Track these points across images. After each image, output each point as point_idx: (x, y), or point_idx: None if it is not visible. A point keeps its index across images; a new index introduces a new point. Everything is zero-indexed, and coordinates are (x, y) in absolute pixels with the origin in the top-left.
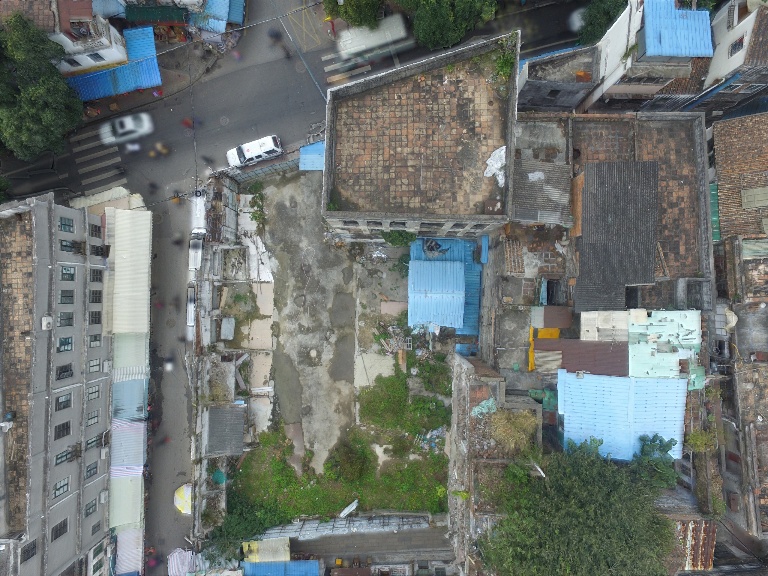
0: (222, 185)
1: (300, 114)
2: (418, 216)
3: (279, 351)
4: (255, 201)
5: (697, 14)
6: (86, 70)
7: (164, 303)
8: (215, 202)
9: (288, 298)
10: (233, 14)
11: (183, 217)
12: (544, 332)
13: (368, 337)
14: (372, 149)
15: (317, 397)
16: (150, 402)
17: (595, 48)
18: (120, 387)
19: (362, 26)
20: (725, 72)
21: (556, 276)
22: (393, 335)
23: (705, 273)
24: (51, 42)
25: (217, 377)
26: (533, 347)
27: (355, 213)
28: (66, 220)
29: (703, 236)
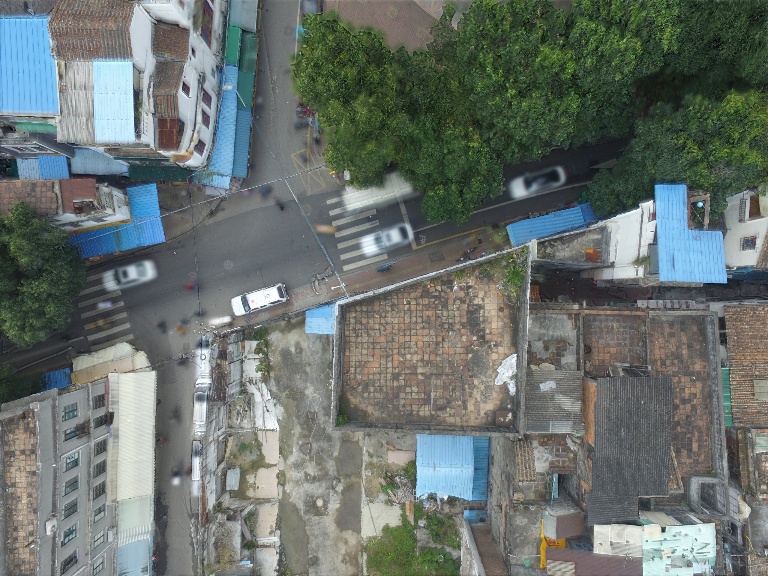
0: (227, 343)
1: (305, 258)
2: (429, 433)
3: (285, 500)
4: (260, 347)
5: (710, 235)
6: (89, 228)
7: (168, 450)
8: (220, 360)
9: (294, 446)
10: (237, 168)
11: (187, 362)
12: None
13: (375, 486)
14: (381, 355)
15: (324, 547)
16: (154, 551)
17: (605, 227)
18: (124, 550)
19: (368, 188)
20: (737, 263)
21: (567, 471)
22: (400, 485)
23: (718, 473)
24: (54, 229)
25: (223, 537)
26: (545, 546)
27: (365, 429)
28: (70, 406)
29: (716, 435)
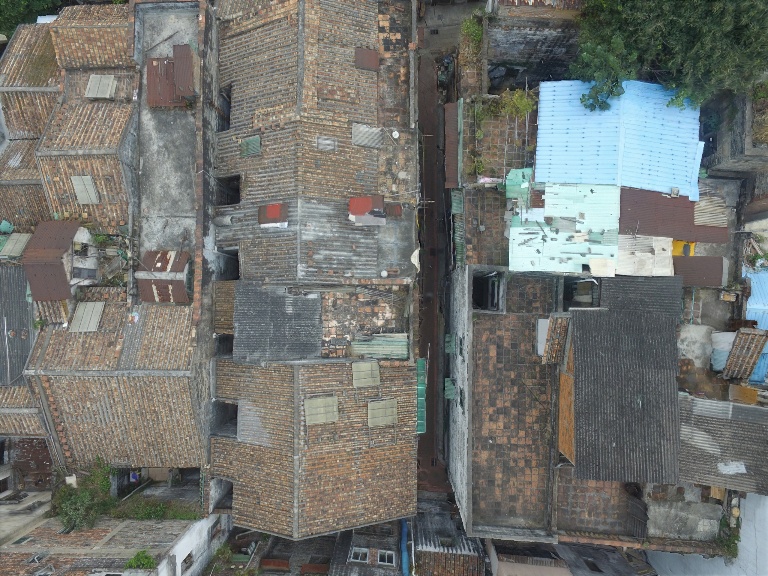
0: None
1: None
2: None
3: None
4: None
5: None
6: None
7: None
8: None
9: None
10: None
11: None
12: (675, 252)
13: None
14: None
15: None
16: None
17: None
18: None
19: None
20: None
21: None
22: (745, 259)
23: None
24: None
25: None
26: None
27: None
28: None
29: None
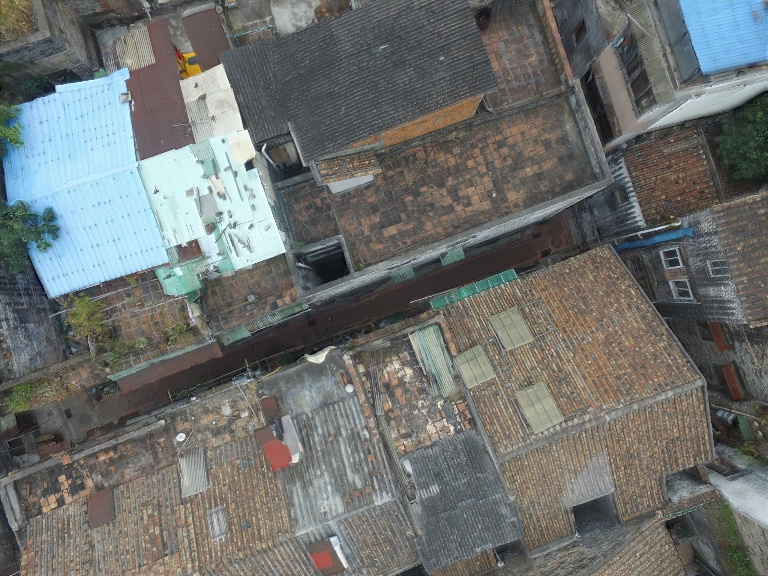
0: None
1: None
2: None
3: None
4: None
5: None
6: None
7: None
8: None
9: None
10: None
11: None
12: None
13: None
14: None
15: None
16: None
17: None
18: None
19: None
20: None
21: None
22: None
23: None
24: None
25: None
26: None
27: None
28: None
29: None
